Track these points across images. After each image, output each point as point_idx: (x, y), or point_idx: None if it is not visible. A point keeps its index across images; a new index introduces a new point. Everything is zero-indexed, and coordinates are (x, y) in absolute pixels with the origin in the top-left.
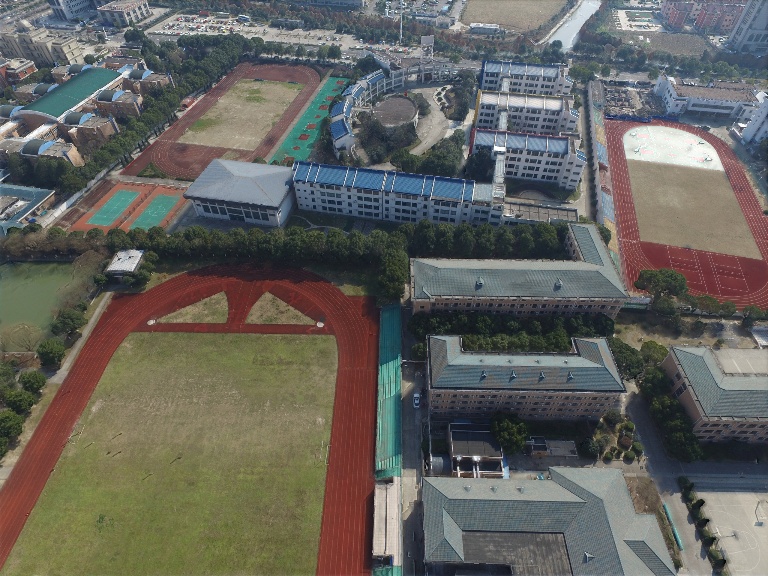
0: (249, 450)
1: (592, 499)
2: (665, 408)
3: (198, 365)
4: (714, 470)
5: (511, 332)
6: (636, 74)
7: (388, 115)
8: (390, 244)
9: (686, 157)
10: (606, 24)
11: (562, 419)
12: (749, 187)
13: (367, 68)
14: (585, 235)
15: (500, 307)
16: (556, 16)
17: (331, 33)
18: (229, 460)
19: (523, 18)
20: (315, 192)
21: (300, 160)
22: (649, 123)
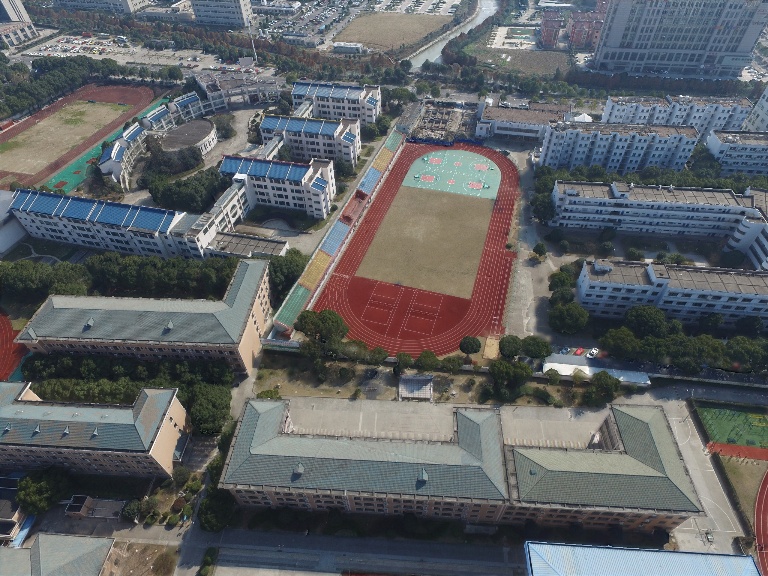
0: None
1: (36, 575)
2: (213, 469)
3: None
4: (255, 541)
5: (117, 377)
6: (473, 94)
7: (177, 139)
8: (61, 278)
9: (464, 184)
10: (476, 42)
11: (131, 475)
12: (509, 217)
13: (188, 90)
14: (242, 272)
15: (118, 349)
16: (430, 34)
17: (196, 53)
18: None
19: (394, 36)
20: (35, 220)
21: (71, 185)
22: (451, 147)
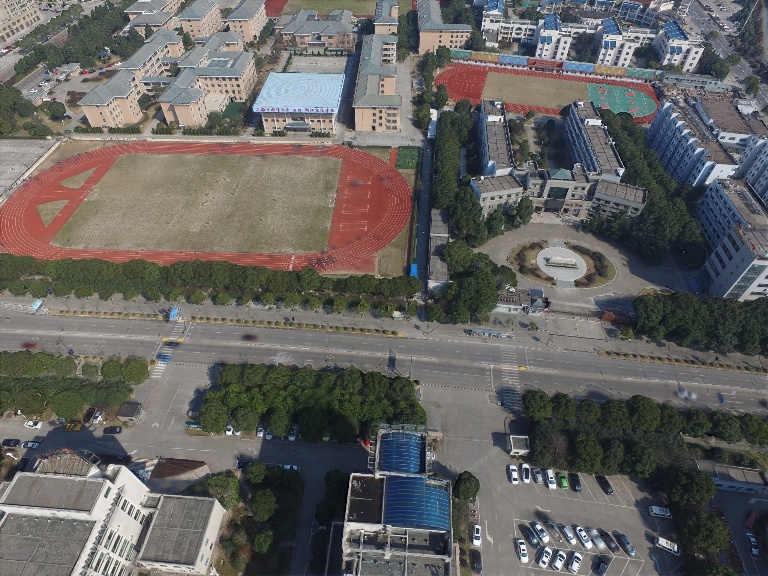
0: (367, 7)
1: None
2: None
3: (398, 0)
4: None
5: None
6: None
7: (586, 13)
8: None
9: (603, 102)
10: None
11: None
12: None
13: None
14: None
15: None
16: None
17: (737, 8)
18: (364, 5)
19: None
20: None
21: None
22: (658, 100)
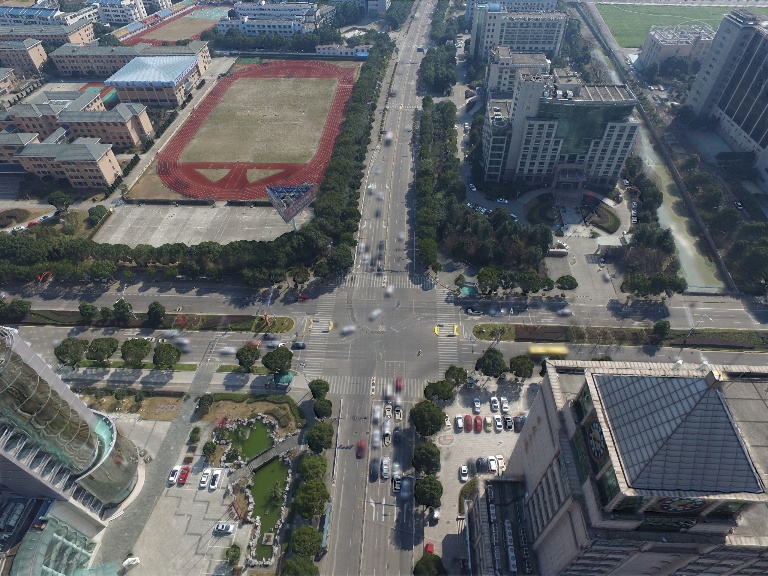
0: None
1: None
2: None
3: None
4: None
5: None
6: None
7: (76, 1)
8: None
9: (213, 16)
10: None
11: None
12: None
13: None
14: None
15: None
16: None
17: None
18: None
19: None
20: None
21: None
22: (220, 6)
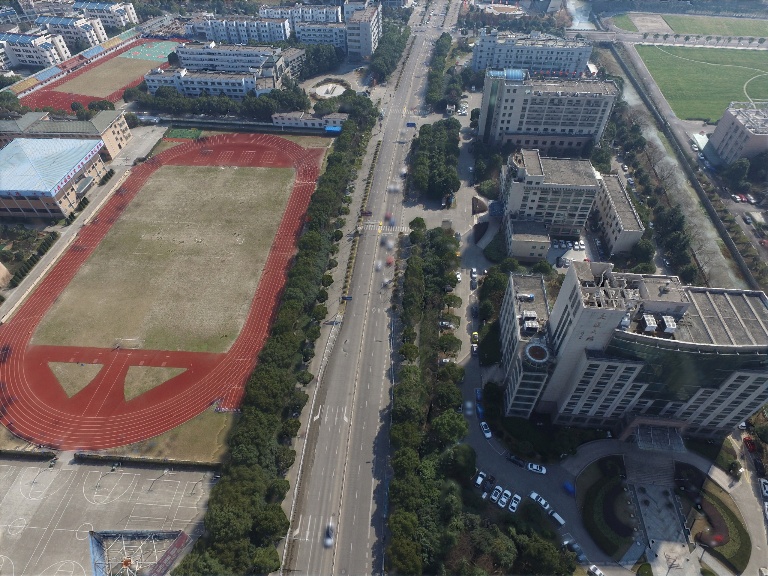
0: None
1: None
2: None
3: None
4: None
5: None
6: None
7: None
8: None
9: (155, 56)
10: None
11: None
12: None
13: None
14: None
15: None
16: None
17: None
18: None
19: None
20: None
21: None
22: (167, 40)
